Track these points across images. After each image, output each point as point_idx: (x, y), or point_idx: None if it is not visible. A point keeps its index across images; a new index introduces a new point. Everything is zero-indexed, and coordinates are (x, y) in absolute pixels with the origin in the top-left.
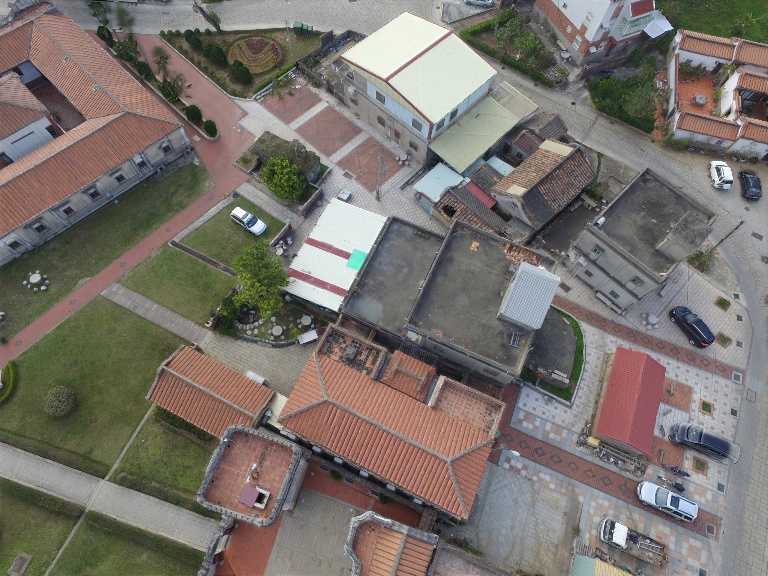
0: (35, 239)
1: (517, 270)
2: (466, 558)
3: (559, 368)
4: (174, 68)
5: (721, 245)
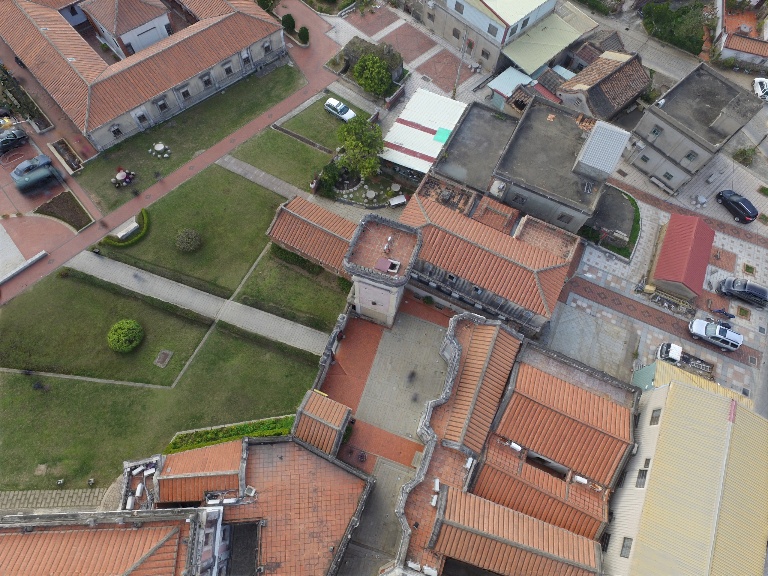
0: (157, 117)
1: (592, 129)
2: (547, 354)
3: (620, 230)
4: None
5: (763, 146)
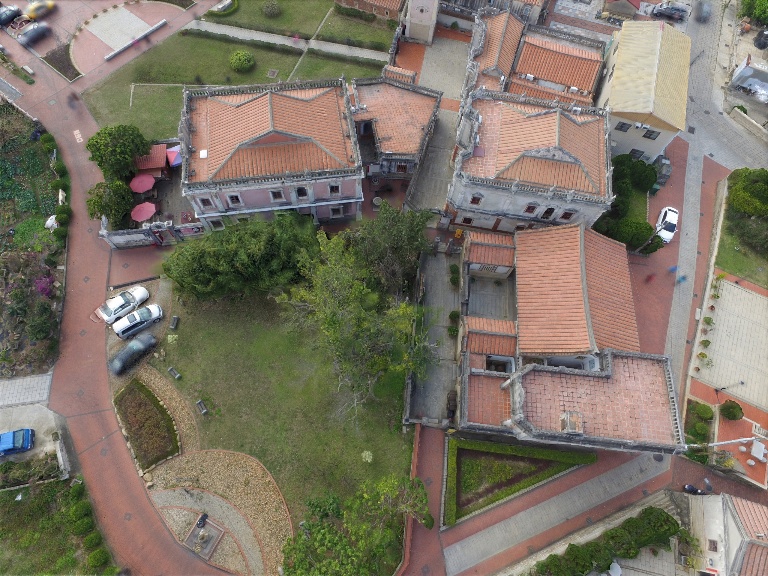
0: None
1: None
2: (542, 33)
3: None
4: None
5: None
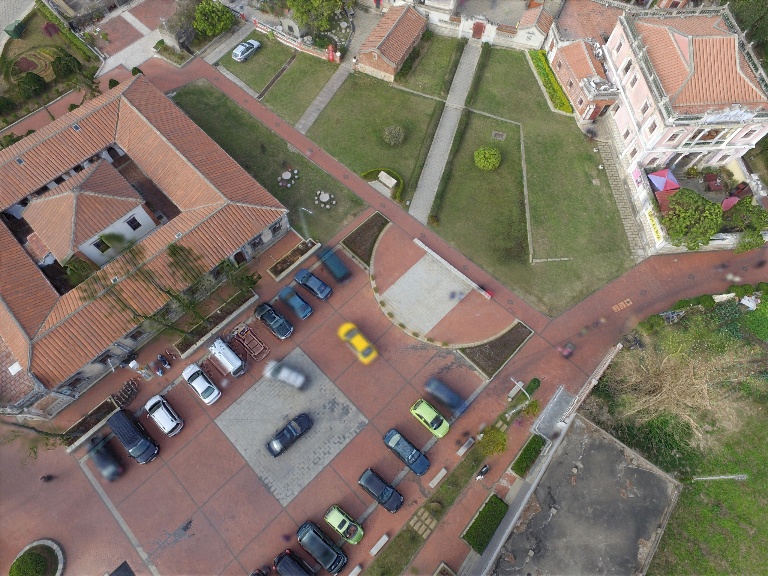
0: None
1: None
2: None
3: None
4: (35, 127)
5: None
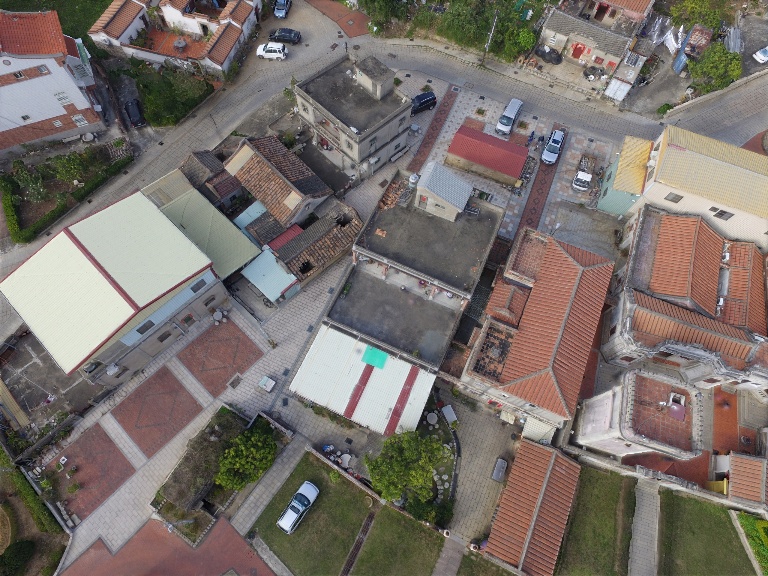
0: None
1: (419, 195)
2: None
3: None
4: None
5: None
